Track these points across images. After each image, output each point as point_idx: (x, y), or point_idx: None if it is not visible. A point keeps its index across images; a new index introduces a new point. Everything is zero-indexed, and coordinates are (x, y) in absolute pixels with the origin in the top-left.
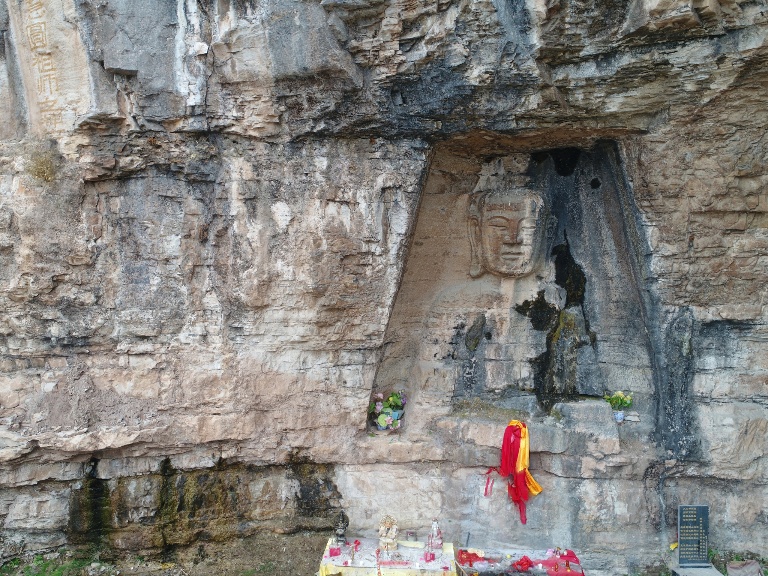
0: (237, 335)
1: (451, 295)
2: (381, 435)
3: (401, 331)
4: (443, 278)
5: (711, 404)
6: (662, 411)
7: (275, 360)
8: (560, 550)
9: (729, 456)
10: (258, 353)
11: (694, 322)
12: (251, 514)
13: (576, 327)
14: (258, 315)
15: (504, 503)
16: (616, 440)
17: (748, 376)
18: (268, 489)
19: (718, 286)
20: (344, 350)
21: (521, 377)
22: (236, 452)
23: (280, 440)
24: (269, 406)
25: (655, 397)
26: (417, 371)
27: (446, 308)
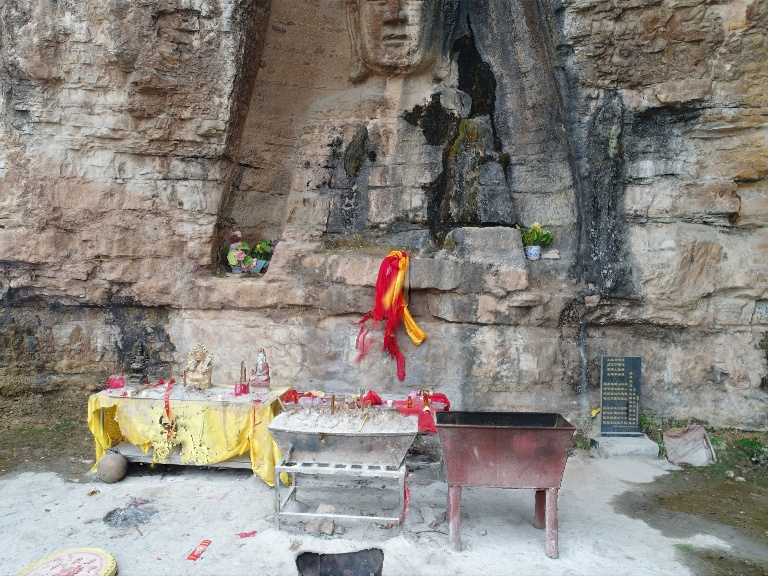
0: (24, 122)
1: (325, 103)
2: (232, 277)
3: (267, 155)
4: (318, 86)
5: (647, 225)
6: (584, 237)
7: (80, 162)
8: (427, 392)
9: (668, 289)
10: (55, 150)
11: (624, 112)
12: (55, 366)
13: (479, 138)
14: (49, 95)
15: (379, 356)
16: (522, 272)
17: (696, 187)
18: (79, 336)
19: (654, 55)
20: (175, 157)
21: (412, 207)
22: (29, 280)
23: (92, 271)
24: (75, 224)
25: (578, 223)
26: (286, 205)
27: (318, 120)
